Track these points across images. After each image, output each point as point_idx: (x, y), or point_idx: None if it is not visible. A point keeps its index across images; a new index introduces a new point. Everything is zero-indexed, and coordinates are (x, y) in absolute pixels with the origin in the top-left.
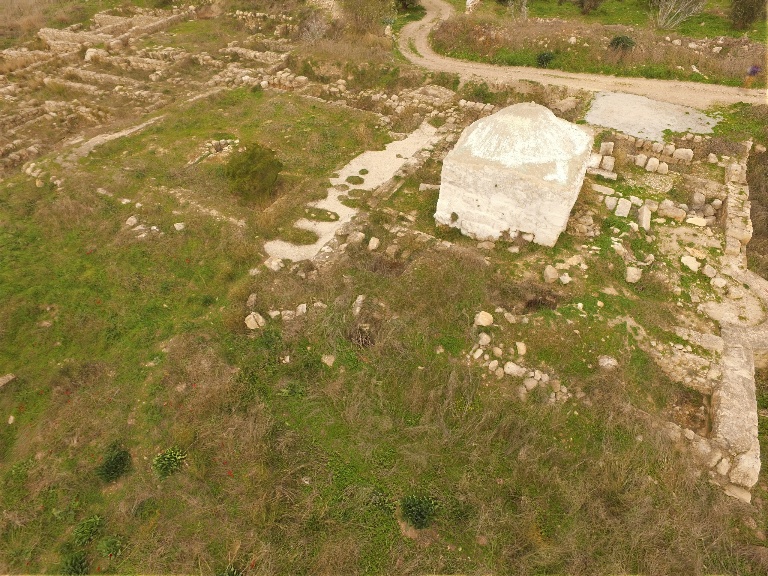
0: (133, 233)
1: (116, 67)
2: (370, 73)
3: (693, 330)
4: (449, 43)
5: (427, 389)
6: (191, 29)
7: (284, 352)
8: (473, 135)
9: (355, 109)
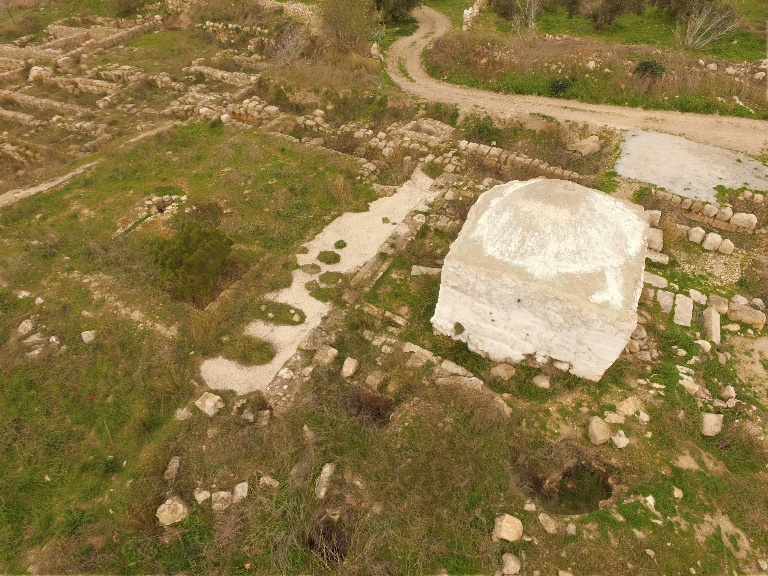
0: (24, 346)
1: (61, 90)
2: (353, 102)
3: None
4: (445, 66)
5: None
6: (154, 42)
7: (210, 574)
8: (484, 219)
9: (333, 152)
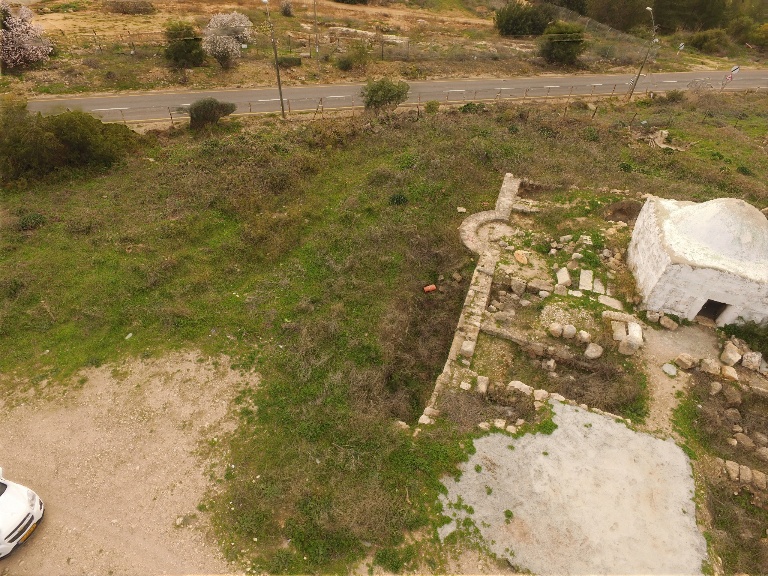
0: None
1: None
2: None
3: (525, 217)
4: None
5: (649, 192)
6: None
7: None
8: None
9: None
